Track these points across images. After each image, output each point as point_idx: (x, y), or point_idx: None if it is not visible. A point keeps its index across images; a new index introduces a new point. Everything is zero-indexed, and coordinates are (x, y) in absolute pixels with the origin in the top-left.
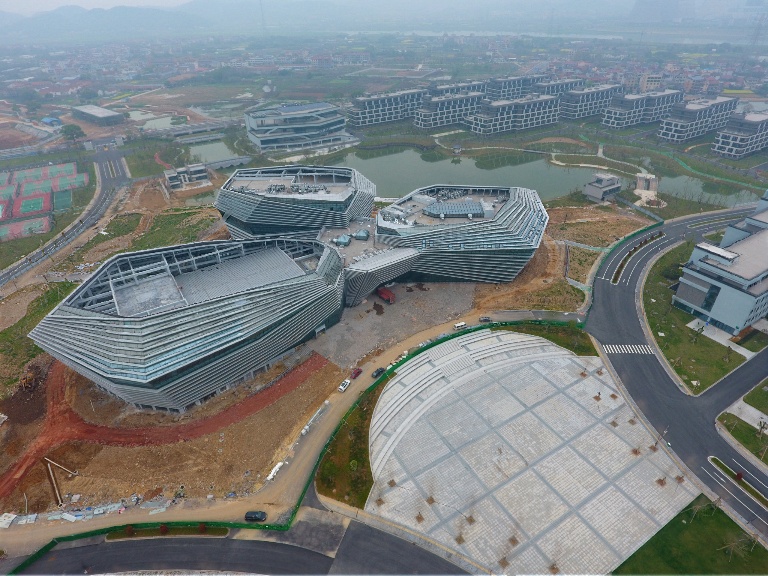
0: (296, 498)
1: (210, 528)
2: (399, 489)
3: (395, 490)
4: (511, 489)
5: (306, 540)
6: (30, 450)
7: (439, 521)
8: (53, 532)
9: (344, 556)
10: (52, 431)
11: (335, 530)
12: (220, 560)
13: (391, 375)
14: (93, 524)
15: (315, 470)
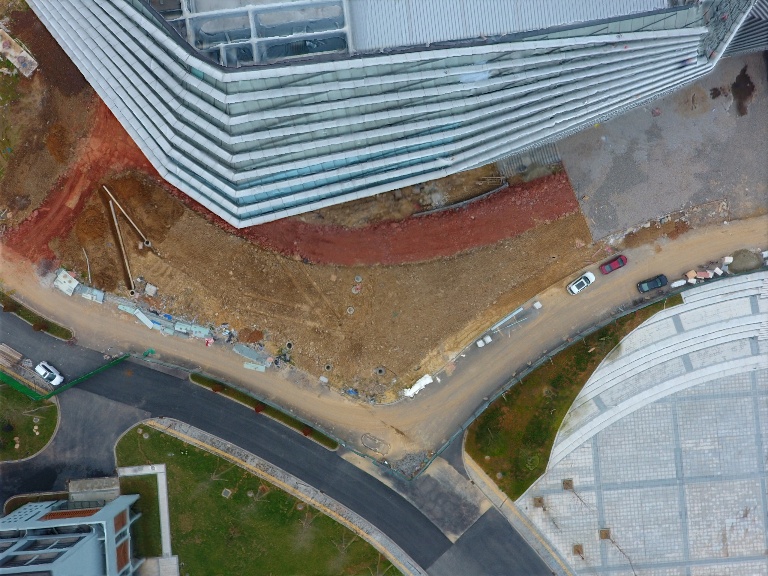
0: (434, 441)
1: (316, 431)
2: (573, 497)
3: (567, 496)
4: (719, 573)
5: (428, 505)
6: (81, 160)
7: (600, 565)
8: (126, 332)
9: (466, 547)
10: (108, 133)
11: (467, 510)
12: (322, 478)
13: (671, 300)
14: (174, 345)
15: (474, 415)
